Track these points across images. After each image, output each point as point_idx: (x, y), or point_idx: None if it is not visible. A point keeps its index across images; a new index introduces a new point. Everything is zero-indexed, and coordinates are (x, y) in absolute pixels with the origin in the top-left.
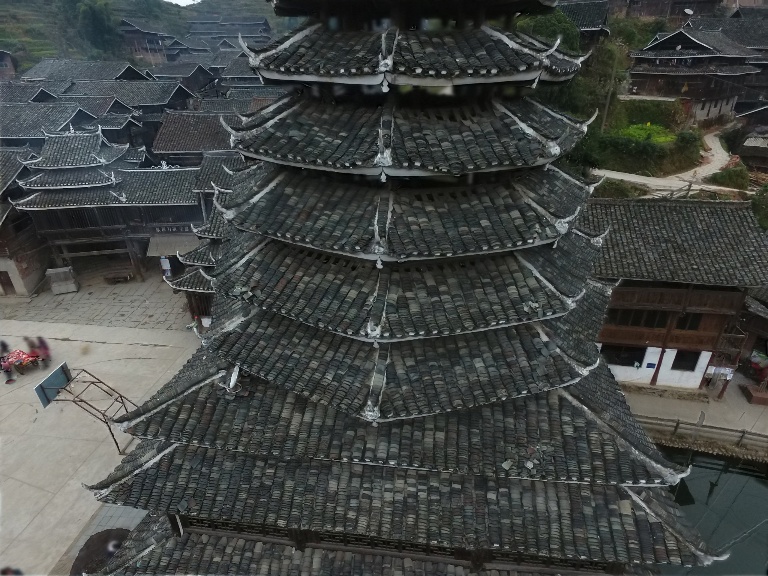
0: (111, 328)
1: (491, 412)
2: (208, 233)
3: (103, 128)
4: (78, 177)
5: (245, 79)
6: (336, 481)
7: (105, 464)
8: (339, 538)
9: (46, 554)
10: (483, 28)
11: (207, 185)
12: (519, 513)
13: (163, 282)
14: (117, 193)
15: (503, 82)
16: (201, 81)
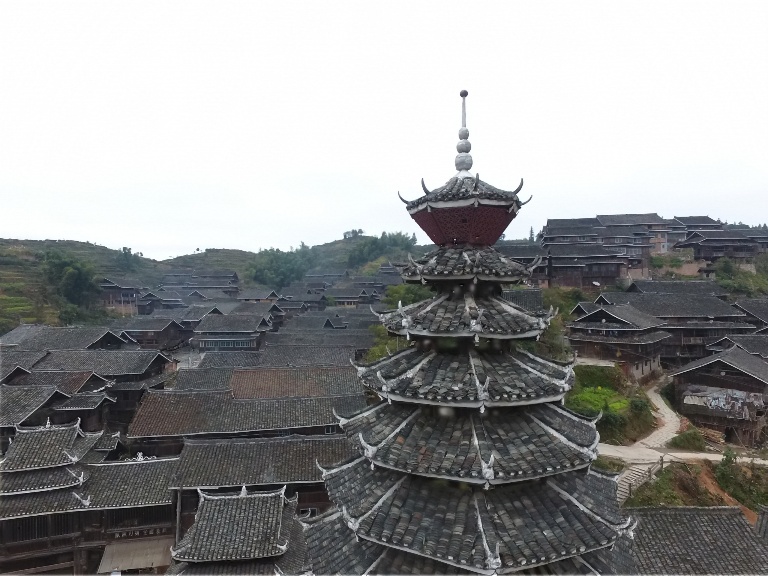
0: None
1: None
2: (188, 556)
3: (75, 409)
4: (41, 479)
5: (216, 334)
6: None
7: None
8: None
9: None
10: (549, 483)
11: (185, 481)
12: None
13: None
14: (81, 495)
15: (587, 552)
16: (171, 334)
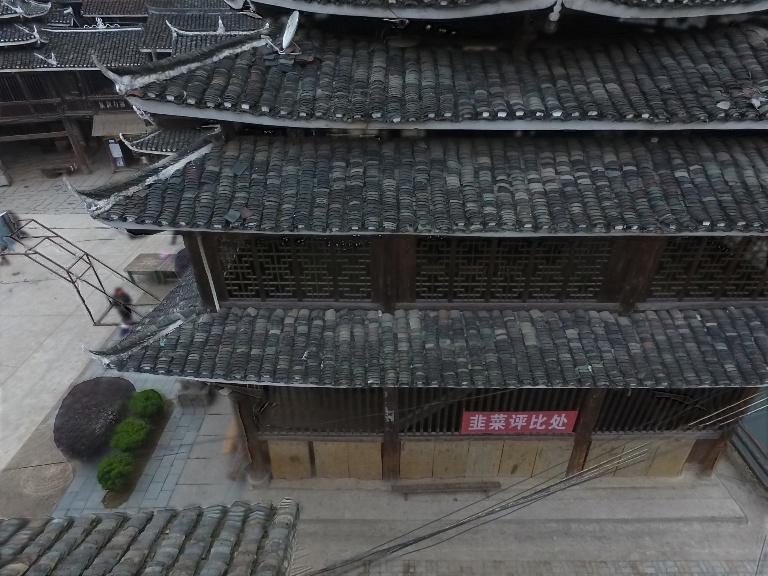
0: (59, 215)
1: (675, 61)
2: None
3: None
4: None
5: None
6: (457, 176)
7: (77, 335)
8: (442, 290)
9: (17, 425)
10: None
11: (158, 44)
12: (725, 189)
13: (115, 173)
14: (44, 55)
15: None
16: None
